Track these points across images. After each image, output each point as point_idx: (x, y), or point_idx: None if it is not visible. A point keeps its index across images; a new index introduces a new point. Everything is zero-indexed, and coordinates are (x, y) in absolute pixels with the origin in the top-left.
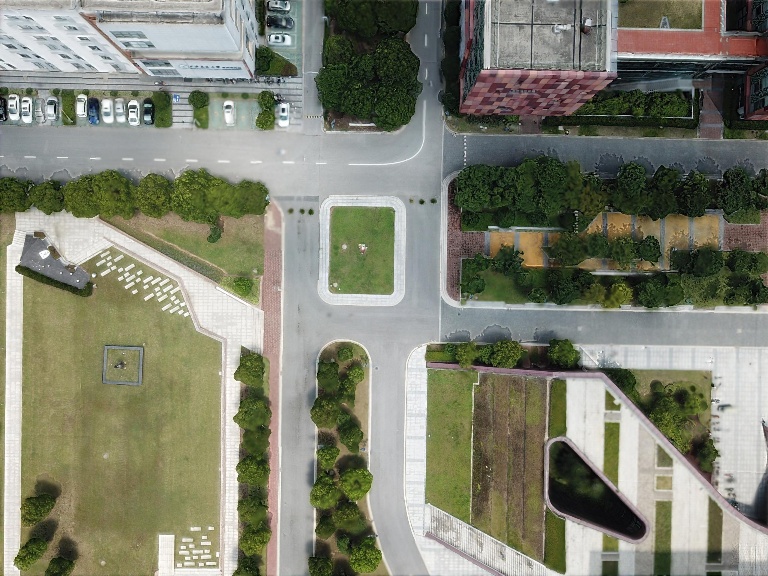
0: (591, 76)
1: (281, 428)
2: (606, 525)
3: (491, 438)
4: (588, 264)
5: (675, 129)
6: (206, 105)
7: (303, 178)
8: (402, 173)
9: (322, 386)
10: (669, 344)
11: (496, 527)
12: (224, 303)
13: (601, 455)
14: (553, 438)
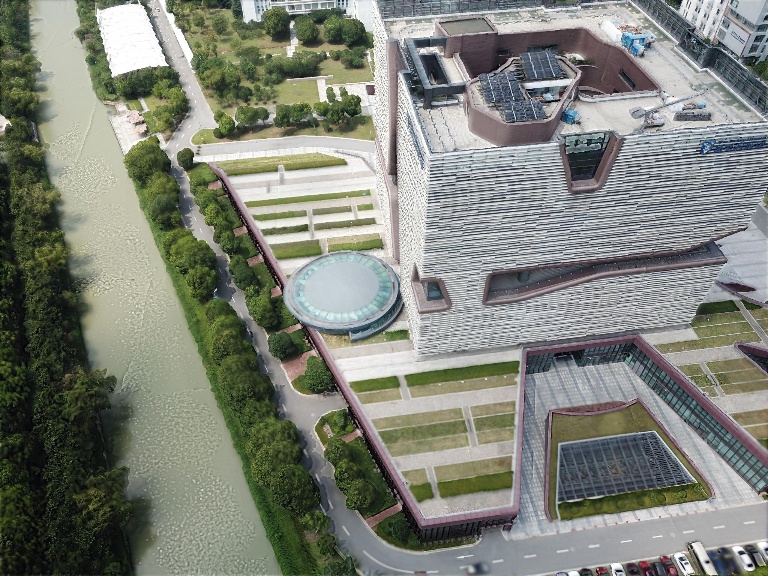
0: None
1: None
2: None
3: None
4: None
5: None
6: None
7: None
8: None
9: None
10: None
11: None
12: None
13: None
14: None
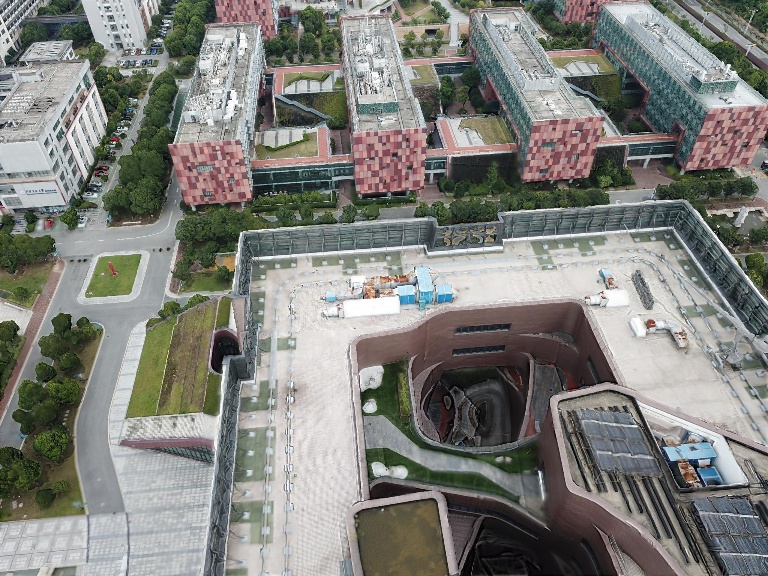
0: (226, 141)
1: (19, 380)
2: None
3: None
4: None
5: (324, 209)
6: (35, 222)
7: (86, 248)
8: (151, 240)
9: (55, 330)
10: None
11: (173, 406)
12: (7, 312)
13: None
14: (217, 328)
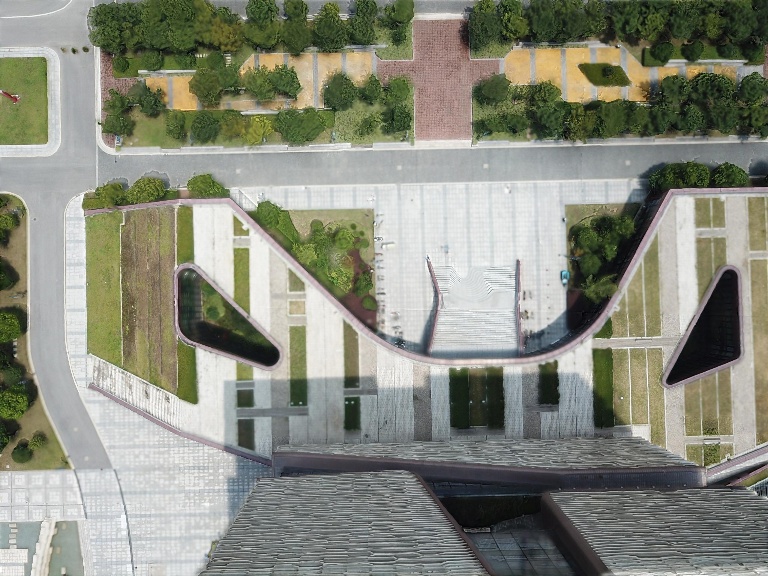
0: None
1: None
2: (250, 358)
3: (135, 276)
4: (242, 106)
5: None
6: None
7: None
8: (54, 24)
9: None
10: (329, 184)
11: (141, 366)
12: None
13: (232, 282)
14: (179, 265)
